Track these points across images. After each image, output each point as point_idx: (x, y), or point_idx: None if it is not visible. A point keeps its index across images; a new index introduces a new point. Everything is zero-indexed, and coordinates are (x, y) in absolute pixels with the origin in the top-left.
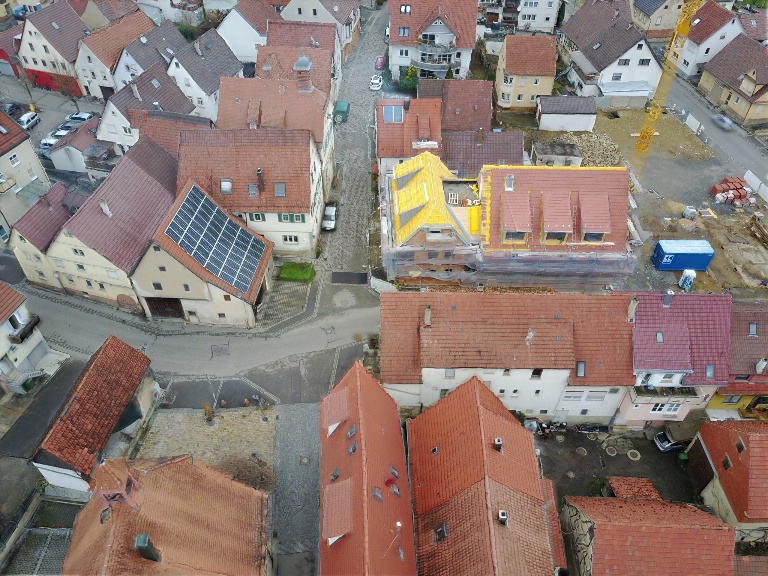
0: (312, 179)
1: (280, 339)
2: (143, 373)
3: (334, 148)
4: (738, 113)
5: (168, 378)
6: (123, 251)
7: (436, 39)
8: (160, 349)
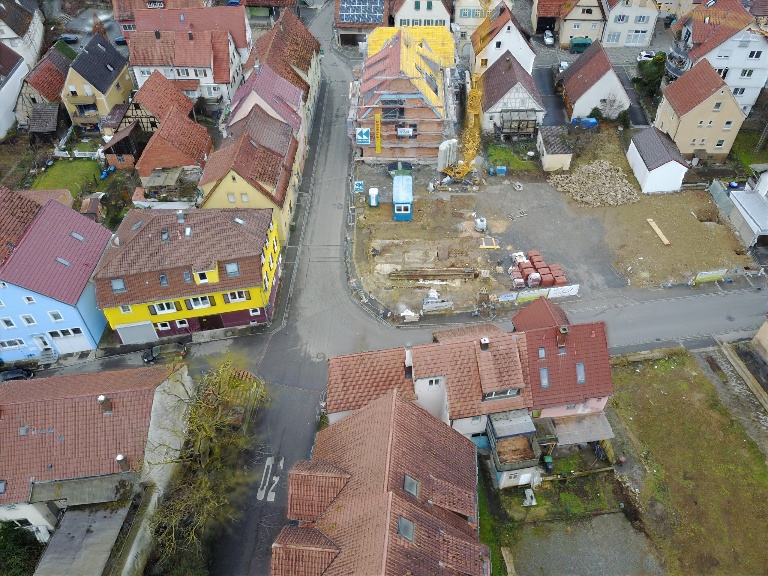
0: (417, 6)
1: (328, 52)
2: (287, 6)
3: None
4: None
5: None
6: None
7: None
8: None
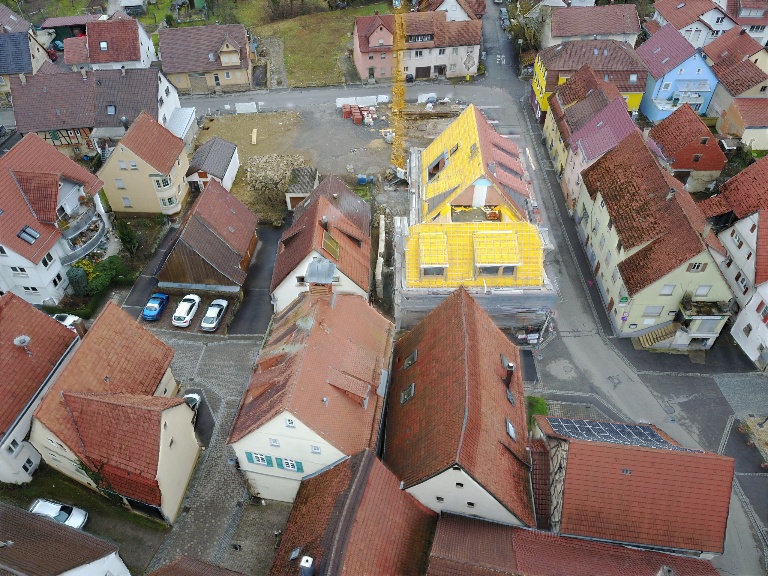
0: None
1: None
2: None
3: (245, 382)
4: (239, 83)
5: (763, 534)
6: (685, 568)
7: (65, 209)
8: (725, 557)
